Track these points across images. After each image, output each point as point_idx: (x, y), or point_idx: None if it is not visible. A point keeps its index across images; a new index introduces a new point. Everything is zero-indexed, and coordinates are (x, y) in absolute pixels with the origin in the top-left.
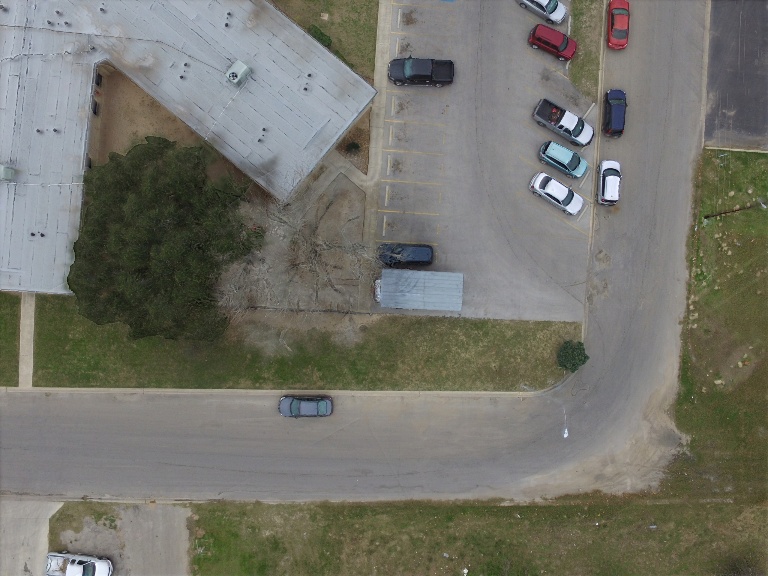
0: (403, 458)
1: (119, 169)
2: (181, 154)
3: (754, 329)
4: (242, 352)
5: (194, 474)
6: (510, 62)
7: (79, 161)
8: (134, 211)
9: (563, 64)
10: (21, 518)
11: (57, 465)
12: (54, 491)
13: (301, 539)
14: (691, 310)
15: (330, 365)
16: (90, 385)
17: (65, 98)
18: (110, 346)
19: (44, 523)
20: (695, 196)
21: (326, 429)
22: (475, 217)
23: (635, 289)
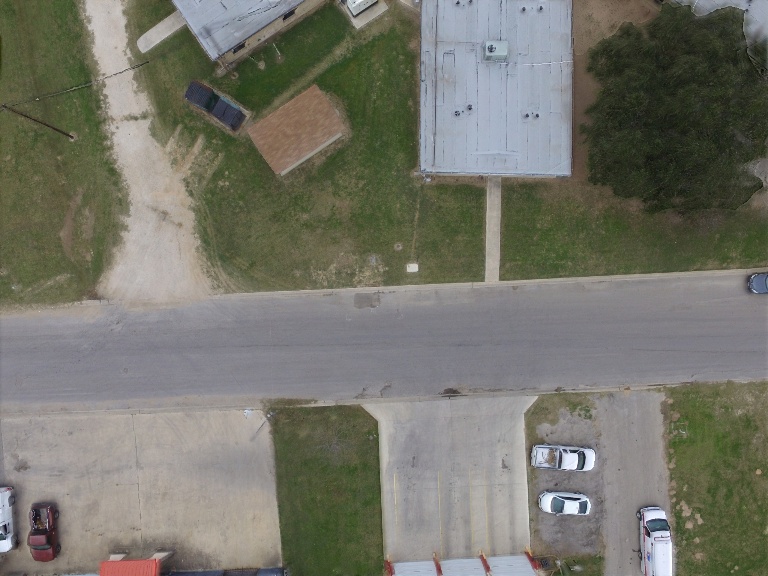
0: None
1: (660, 32)
2: (735, 11)
3: None
4: (711, 232)
5: (667, 358)
6: None
7: (567, 39)
8: (707, 67)
9: None
10: (496, 415)
11: (529, 358)
12: (527, 385)
13: None
14: None
15: None
16: (559, 275)
17: None
18: (579, 234)
19: (519, 418)
20: None
21: None
22: None
23: None
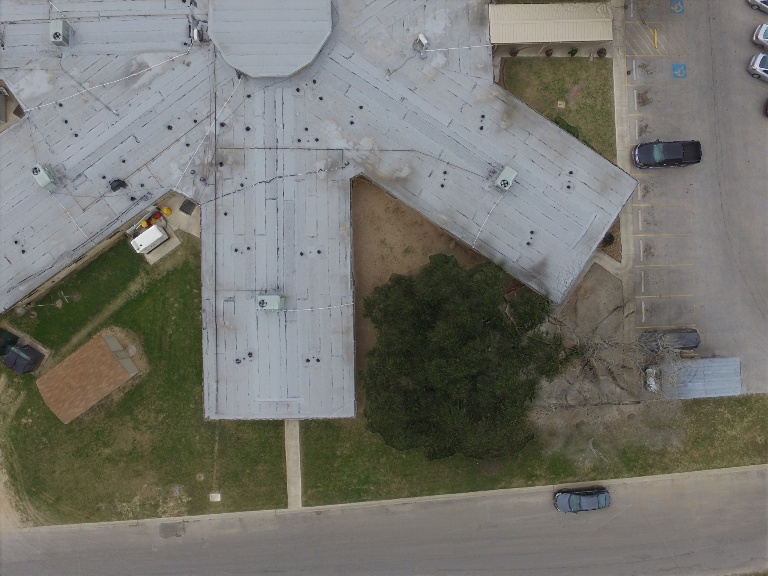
0: (678, 539)
1: (418, 296)
2: (488, 277)
3: None
4: None
5: None
6: (747, 134)
7: (346, 281)
8: (454, 342)
9: None
10: None
11: None
12: None
13: None
14: None
15: None
16: (361, 500)
17: (324, 217)
18: (379, 459)
19: None
20: None
21: (600, 519)
22: (729, 294)
23: None
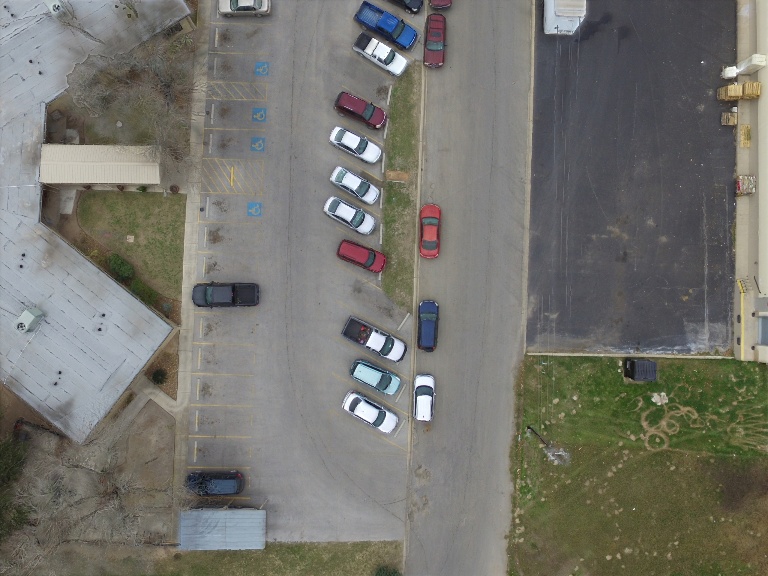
0: None
1: None
2: None
3: (585, 540)
4: None
5: None
6: (320, 276)
7: None
8: None
9: (375, 275)
10: None
11: None
12: None
13: None
14: (517, 523)
15: None
16: None
17: None
18: None
19: None
20: (518, 405)
21: None
22: (288, 438)
23: (457, 504)
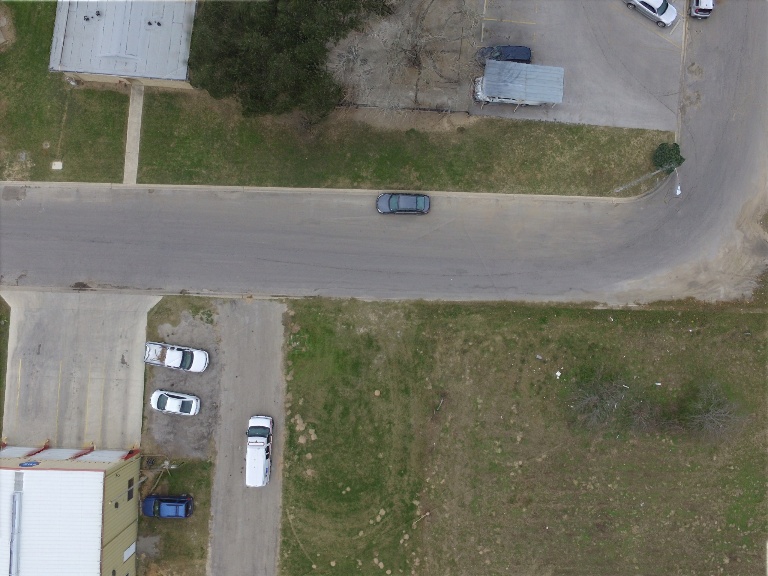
0: (497, 259)
1: None
2: None
3: None
4: (342, 151)
5: (291, 270)
6: None
7: None
8: None
9: None
10: (120, 311)
11: (157, 259)
12: (153, 285)
13: (395, 337)
14: None
15: (427, 166)
16: (192, 182)
17: None
18: (214, 144)
19: (142, 316)
20: None
21: (422, 229)
22: (570, 27)
23: (727, 101)
